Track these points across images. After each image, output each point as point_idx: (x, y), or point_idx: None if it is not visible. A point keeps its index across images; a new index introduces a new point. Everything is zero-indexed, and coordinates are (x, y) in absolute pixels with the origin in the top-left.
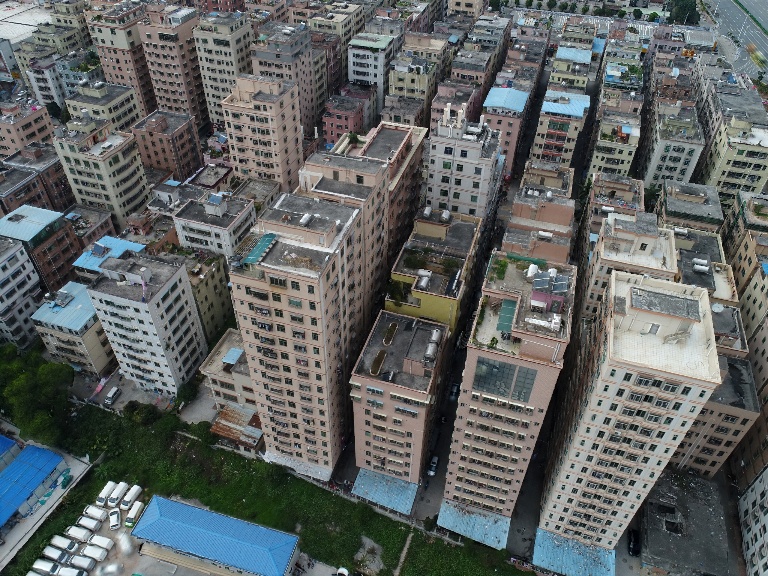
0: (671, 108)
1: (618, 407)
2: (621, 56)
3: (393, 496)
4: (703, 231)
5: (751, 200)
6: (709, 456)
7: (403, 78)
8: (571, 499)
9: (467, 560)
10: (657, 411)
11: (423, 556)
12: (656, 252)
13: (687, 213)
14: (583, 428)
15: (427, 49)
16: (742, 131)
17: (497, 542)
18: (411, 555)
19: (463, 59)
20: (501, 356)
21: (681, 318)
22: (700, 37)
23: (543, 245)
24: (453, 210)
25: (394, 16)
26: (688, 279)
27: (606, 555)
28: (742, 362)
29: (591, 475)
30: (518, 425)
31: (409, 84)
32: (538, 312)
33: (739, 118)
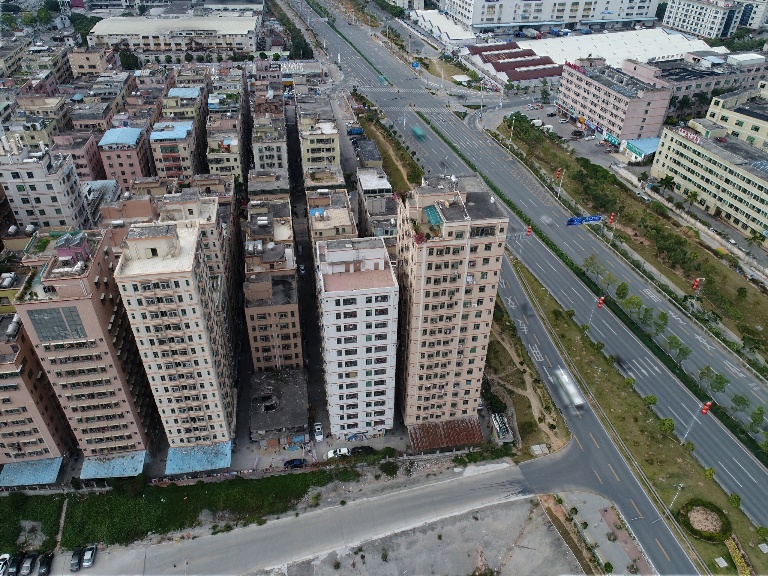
0: (263, 120)
1: (147, 315)
2: (226, 88)
3: (38, 474)
4: (277, 200)
5: (307, 171)
6: (290, 351)
7: (22, 136)
8: (173, 409)
9: (118, 499)
10: (170, 307)
11: (78, 512)
12: (204, 214)
13: (262, 190)
14: (137, 342)
15: (41, 108)
16: (309, 126)
17: (134, 471)
18: (68, 516)
19: (81, 111)
20: (42, 304)
21: (162, 237)
22: (310, 67)
23: (119, 231)
24: (46, 226)
25: (9, 85)
26: (254, 233)
27: (224, 446)
28: (291, 276)
29: (169, 380)
30: (93, 360)
31: (30, 141)
32: (68, 265)
33: (304, 117)
